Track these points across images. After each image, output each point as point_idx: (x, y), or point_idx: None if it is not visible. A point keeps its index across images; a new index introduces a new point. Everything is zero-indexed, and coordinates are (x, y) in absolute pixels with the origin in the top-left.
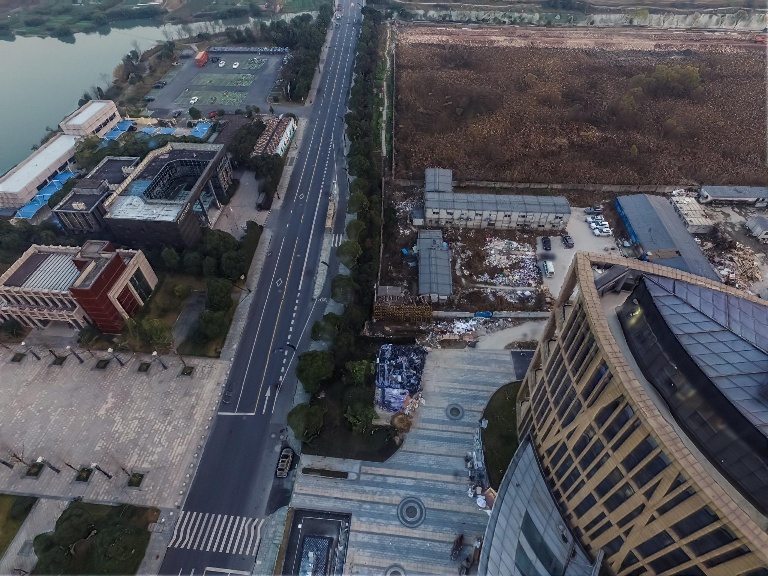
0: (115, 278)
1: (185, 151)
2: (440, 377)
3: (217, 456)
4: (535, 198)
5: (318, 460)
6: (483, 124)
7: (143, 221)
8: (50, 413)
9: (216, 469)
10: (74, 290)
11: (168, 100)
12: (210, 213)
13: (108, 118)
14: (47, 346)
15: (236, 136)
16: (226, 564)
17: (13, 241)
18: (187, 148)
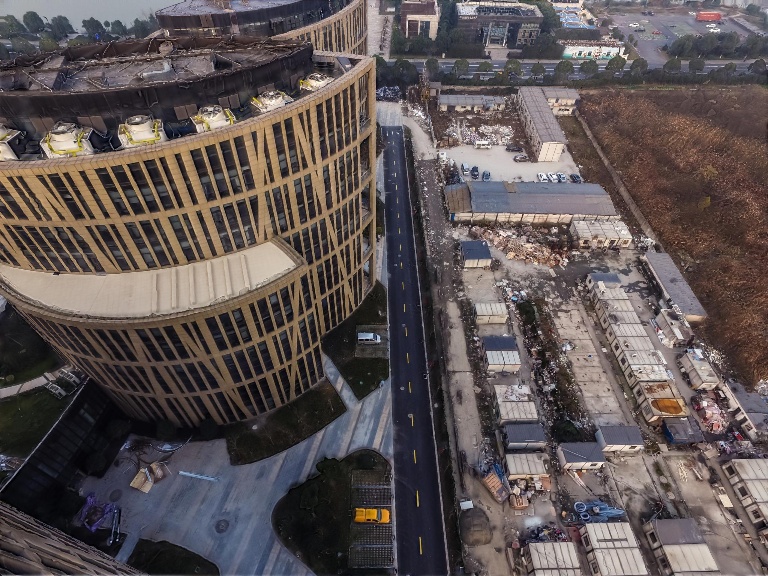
0: (417, 14)
1: (533, 12)
2: (382, 106)
3: None
4: (557, 129)
5: None
6: (689, 121)
7: None
8: None
9: None
10: None
11: (628, 19)
12: (497, 45)
13: (571, 0)
14: None
15: (573, 29)
16: None
17: (445, 3)
18: (536, 12)
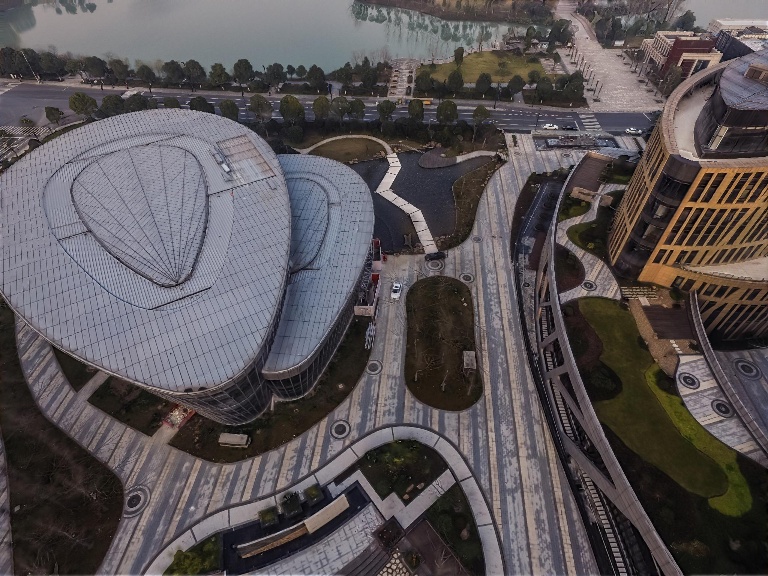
0: (696, 51)
1: None
2: None
3: (622, 116)
4: None
5: (643, 141)
6: None
7: (746, 46)
8: (609, 77)
9: (616, 117)
10: (677, 39)
11: None
12: None
13: None
14: (639, 68)
15: None
16: (580, 125)
17: None
18: None
